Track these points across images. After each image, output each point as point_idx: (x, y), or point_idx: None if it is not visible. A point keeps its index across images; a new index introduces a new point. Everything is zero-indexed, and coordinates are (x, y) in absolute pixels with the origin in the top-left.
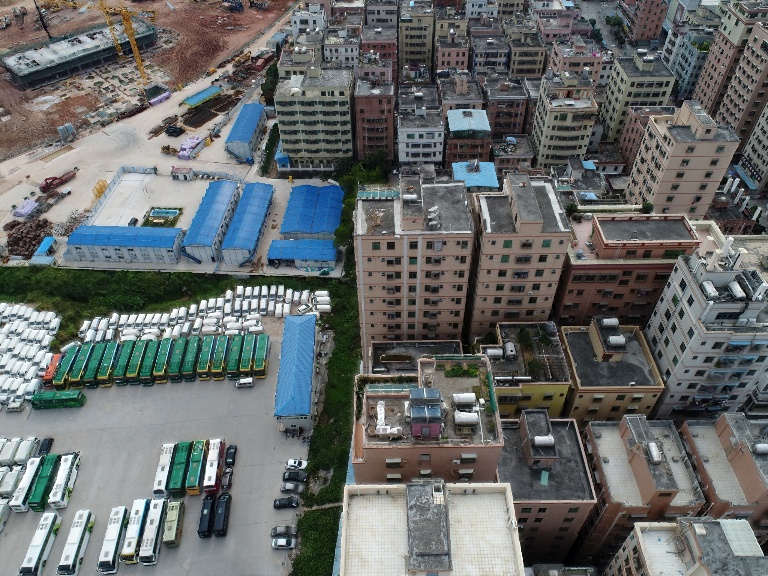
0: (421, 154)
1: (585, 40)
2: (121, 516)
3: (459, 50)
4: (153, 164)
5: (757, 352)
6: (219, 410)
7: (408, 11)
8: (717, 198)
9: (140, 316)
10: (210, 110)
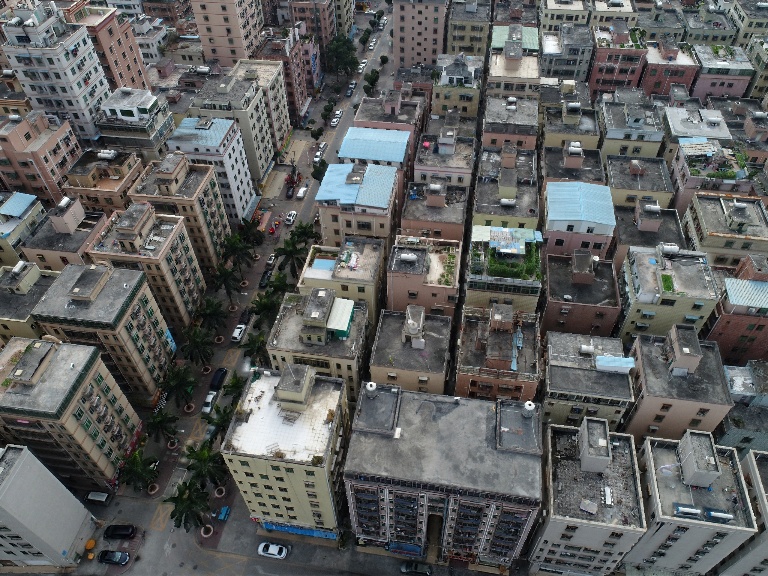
0: (127, 15)
1: None
2: None
3: None
4: None
5: (44, 67)
6: None
7: None
8: (273, 41)
9: None
10: None
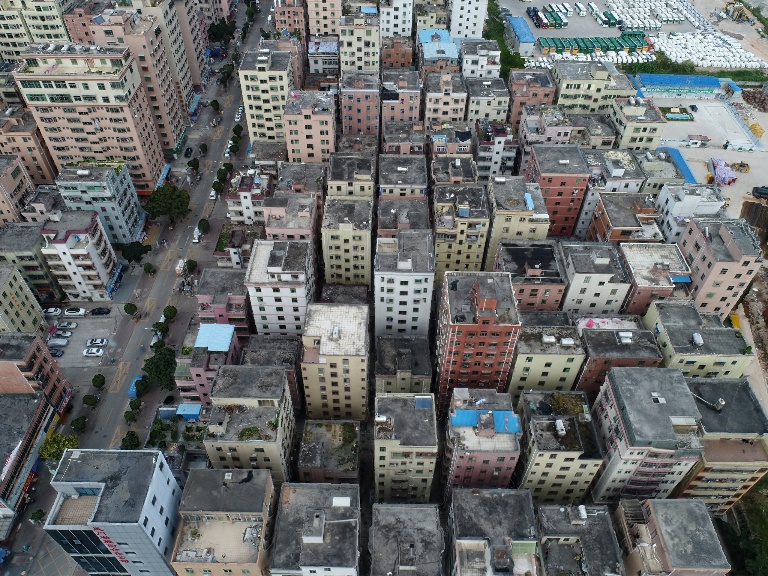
0: None
1: (293, 115)
2: (568, 8)
3: (446, 156)
4: (741, 158)
5: None
6: (552, 36)
7: (532, 196)
8: None
9: (625, 58)
10: (759, 228)
